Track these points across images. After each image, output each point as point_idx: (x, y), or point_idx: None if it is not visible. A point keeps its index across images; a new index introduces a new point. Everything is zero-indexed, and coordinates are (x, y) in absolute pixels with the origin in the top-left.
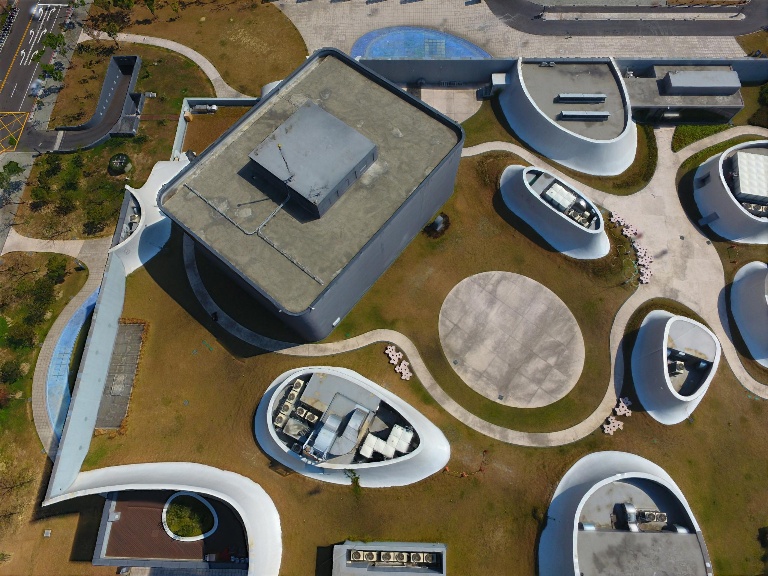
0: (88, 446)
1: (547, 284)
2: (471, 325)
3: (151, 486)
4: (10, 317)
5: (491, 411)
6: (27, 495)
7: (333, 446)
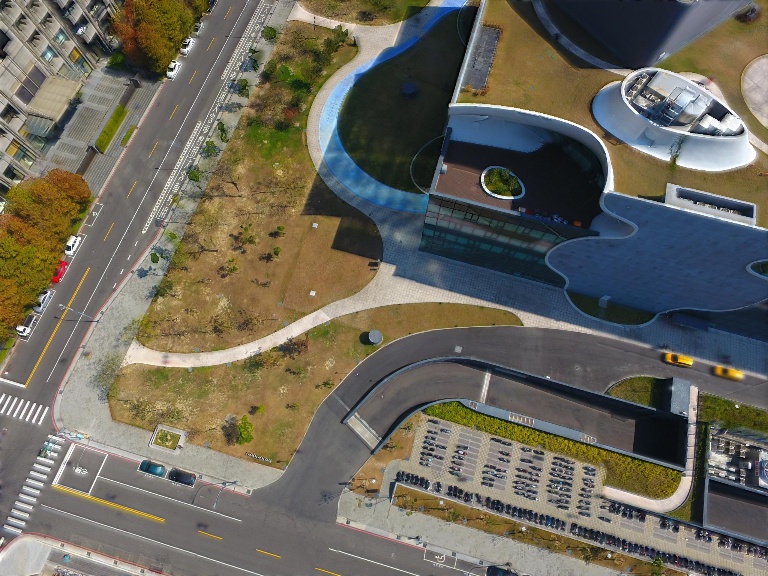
0: None
1: None
2: None
3: (531, 112)
4: (292, 68)
5: None
6: (299, 196)
7: (687, 107)
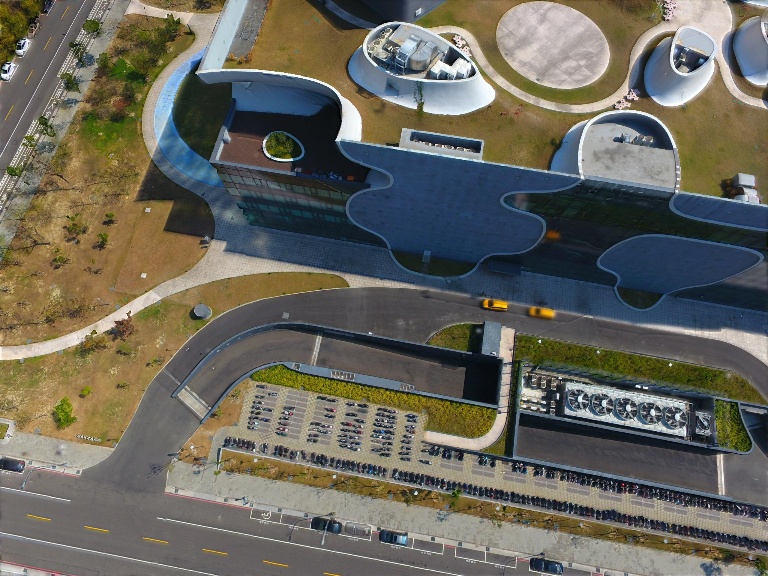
0: (222, 65)
1: (587, 14)
2: (522, 33)
3: (275, 72)
4: (129, 60)
5: (529, 86)
6: (133, 183)
7: (413, 54)
